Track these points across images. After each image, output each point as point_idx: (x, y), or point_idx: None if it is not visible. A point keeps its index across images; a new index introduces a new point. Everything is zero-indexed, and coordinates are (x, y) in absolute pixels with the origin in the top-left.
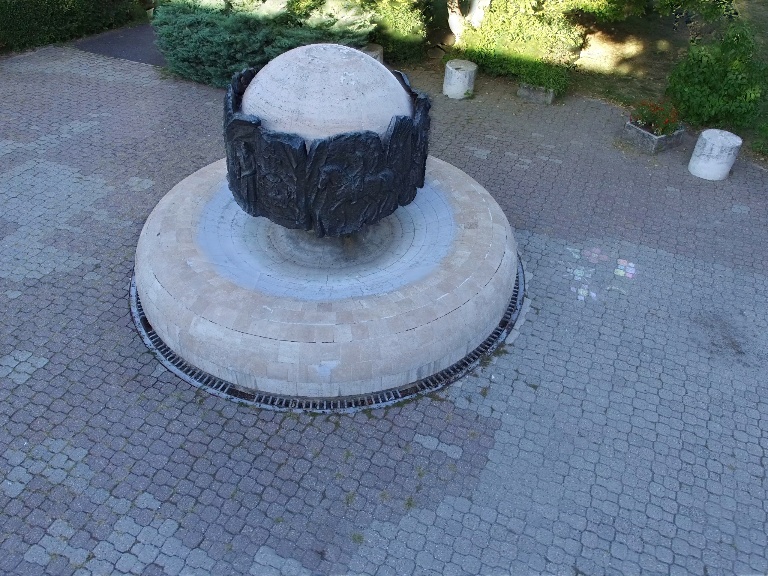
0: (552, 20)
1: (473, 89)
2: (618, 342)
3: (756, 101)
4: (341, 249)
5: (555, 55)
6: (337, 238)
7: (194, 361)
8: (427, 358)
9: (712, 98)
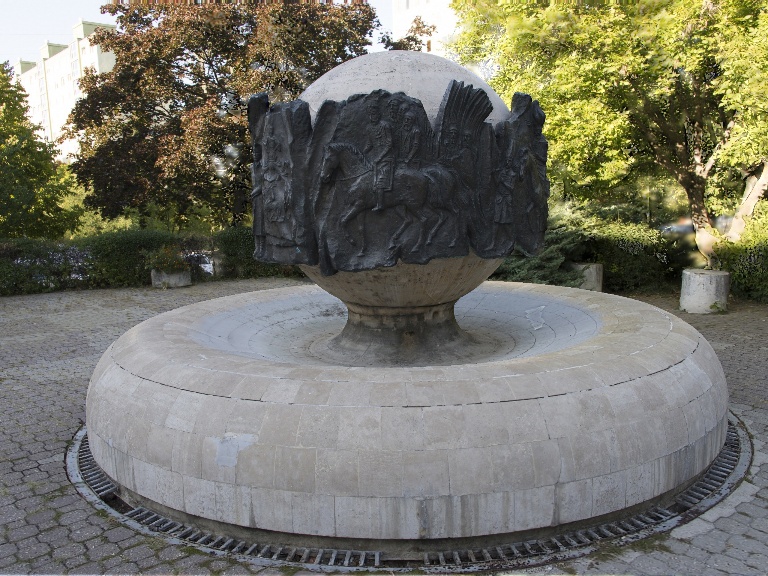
0: None
1: (726, 305)
2: None
3: None
4: (395, 349)
5: None
6: (392, 332)
7: (90, 442)
8: (442, 479)
9: None
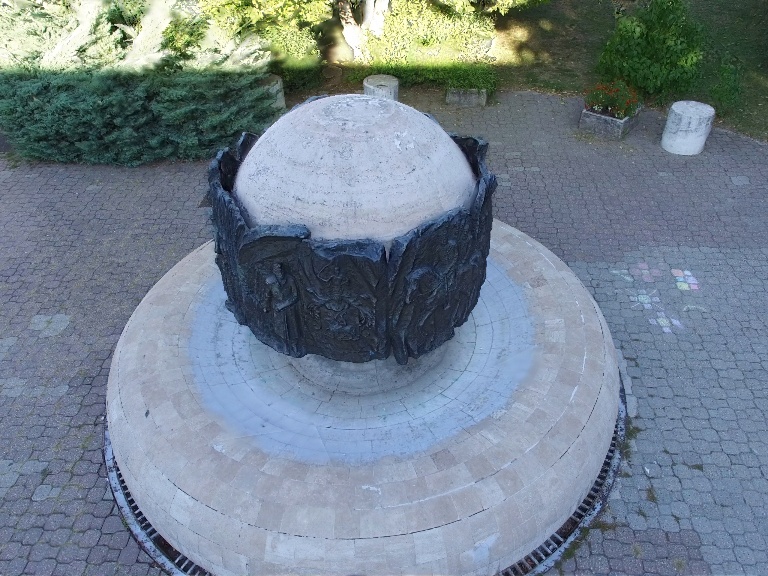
0: (462, 14)
1: None
2: (741, 375)
3: (698, 64)
4: None
5: (470, 51)
6: None
7: None
8: (586, 482)
9: (654, 68)
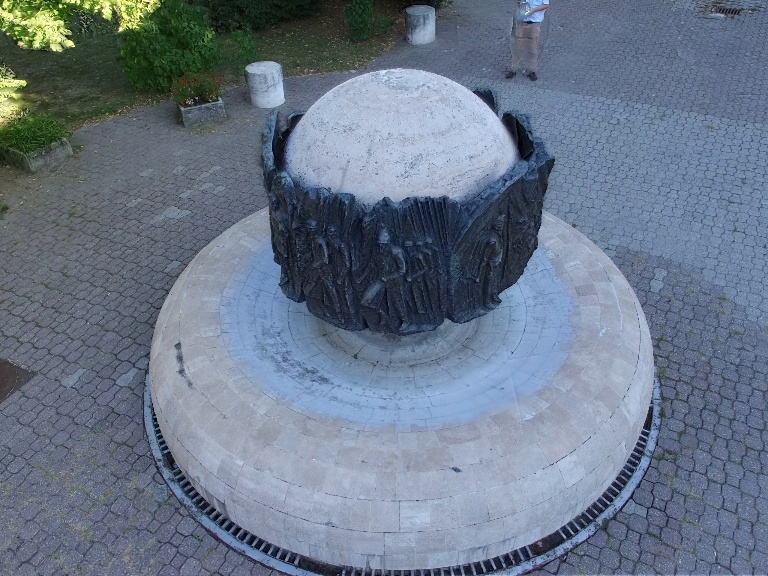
0: None
1: None
2: None
3: (212, 39)
4: None
5: None
6: None
7: None
8: None
9: (187, 55)
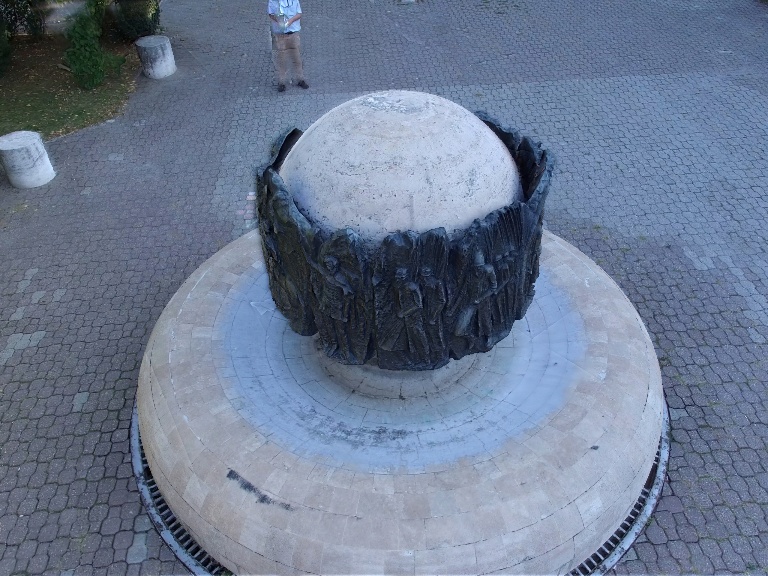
0: None
1: None
2: None
3: None
4: None
5: None
6: None
7: None
8: None
9: None
